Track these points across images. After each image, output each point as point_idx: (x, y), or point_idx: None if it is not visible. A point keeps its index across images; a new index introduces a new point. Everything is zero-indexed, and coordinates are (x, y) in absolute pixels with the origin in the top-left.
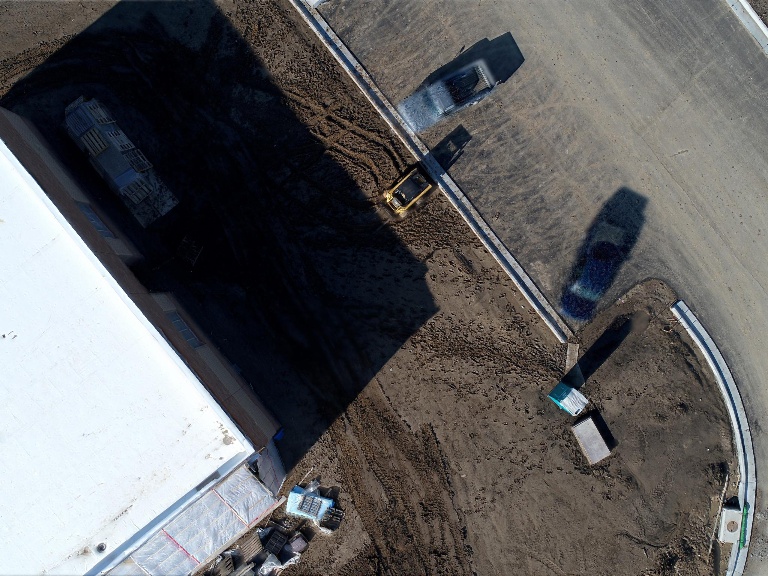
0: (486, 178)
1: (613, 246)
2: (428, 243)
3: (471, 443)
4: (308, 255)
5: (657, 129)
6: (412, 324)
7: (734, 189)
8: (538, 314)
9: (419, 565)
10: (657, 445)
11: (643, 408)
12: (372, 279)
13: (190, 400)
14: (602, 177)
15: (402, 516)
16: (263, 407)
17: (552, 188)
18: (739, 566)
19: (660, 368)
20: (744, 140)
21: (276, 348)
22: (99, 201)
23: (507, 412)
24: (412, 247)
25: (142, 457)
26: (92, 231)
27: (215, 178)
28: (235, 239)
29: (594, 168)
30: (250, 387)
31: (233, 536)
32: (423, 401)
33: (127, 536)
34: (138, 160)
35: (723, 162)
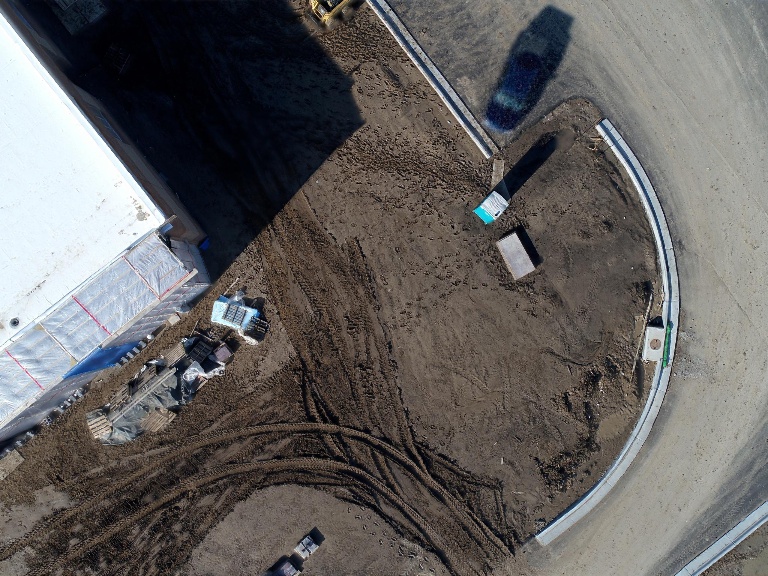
0: None
1: (539, 63)
2: (355, 55)
3: (397, 257)
4: (235, 64)
5: None
6: (338, 136)
7: (658, 8)
8: (464, 129)
9: (344, 379)
10: (581, 262)
11: (568, 225)
12: (299, 90)
13: (104, 175)
14: None
15: (327, 329)
16: (188, 214)
17: (479, 4)
18: (662, 385)
19: (585, 185)
20: None
21: (202, 158)
22: (26, 7)
23: (433, 227)
24: (339, 59)
25: (55, 232)
26: (9, 10)
27: None
28: (162, 47)
29: None
30: (176, 196)
31: (144, 307)
32: (349, 214)
33: (40, 312)
34: None
35: None
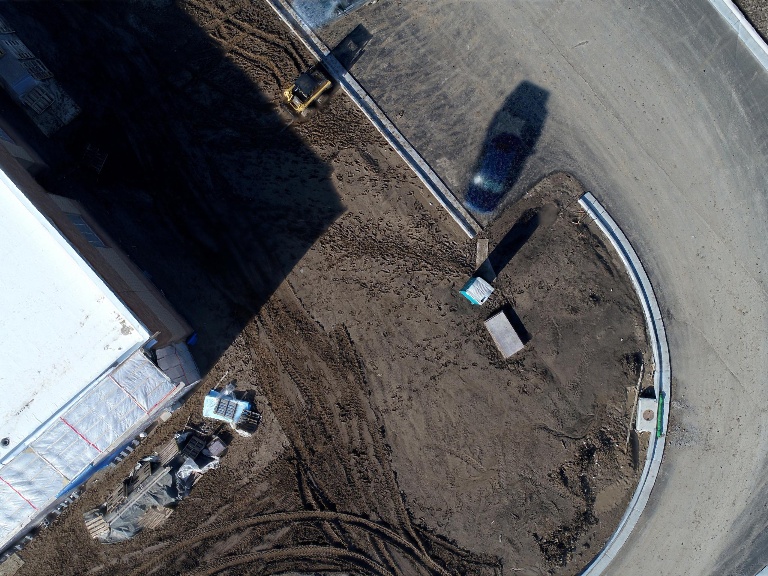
0: (388, 76)
1: (518, 140)
2: (333, 143)
3: (385, 342)
4: (213, 159)
5: (557, 21)
6: (320, 224)
7: (636, 78)
8: (446, 210)
9: (339, 466)
10: (570, 337)
11: (555, 300)
12: (278, 181)
13: (86, 292)
14: (504, 71)
15: (319, 417)
16: (174, 312)
17: (455, 84)
18: (657, 454)
19: (570, 260)
20: (643, 29)
21: (186, 253)
22: (2, 113)
23: (420, 310)
24: (317, 147)
25: (41, 351)
26: None
27: (117, 85)
28: (139, 146)
29: (496, 63)
30: (161, 293)
31: (133, 423)
32: (335, 301)
33: (30, 430)
34: (38, 69)
35: (623, 52)
